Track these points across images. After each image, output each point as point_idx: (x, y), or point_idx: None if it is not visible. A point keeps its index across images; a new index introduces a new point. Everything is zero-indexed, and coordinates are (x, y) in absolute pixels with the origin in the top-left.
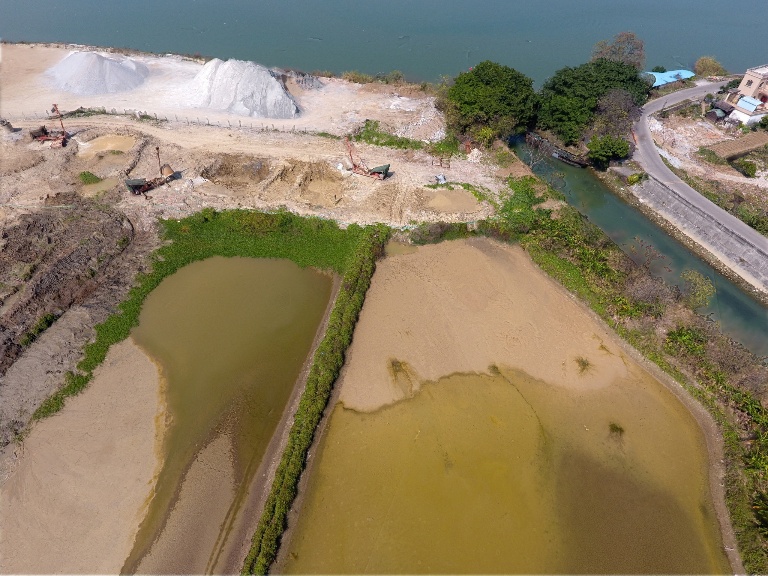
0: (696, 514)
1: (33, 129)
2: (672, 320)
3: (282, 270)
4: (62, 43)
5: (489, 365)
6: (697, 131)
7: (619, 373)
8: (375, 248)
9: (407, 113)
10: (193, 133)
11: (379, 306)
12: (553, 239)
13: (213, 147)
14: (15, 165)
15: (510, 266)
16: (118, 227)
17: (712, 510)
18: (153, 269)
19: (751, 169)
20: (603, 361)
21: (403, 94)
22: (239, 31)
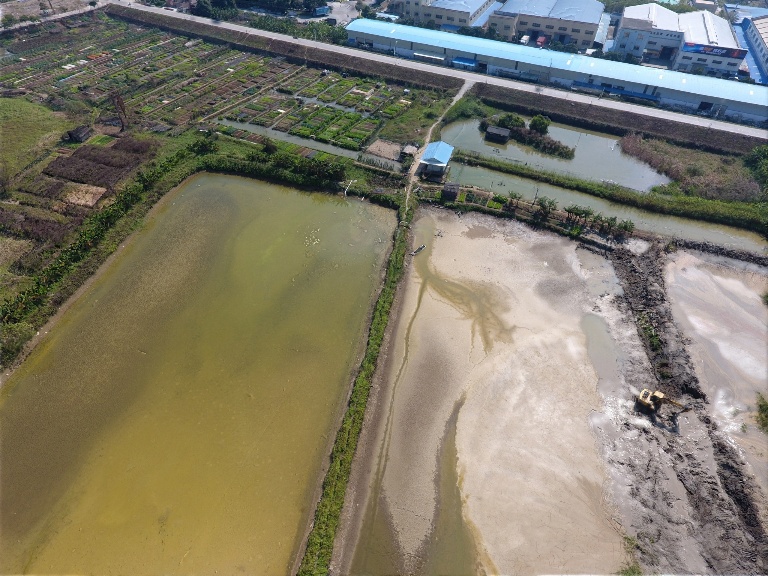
0: None
1: None
2: None
3: None
4: None
5: None
6: None
7: None
8: None
9: None
10: None
11: None
12: None
13: None
14: None
15: None
16: None
17: None
18: None
19: None
20: None
21: None
22: None
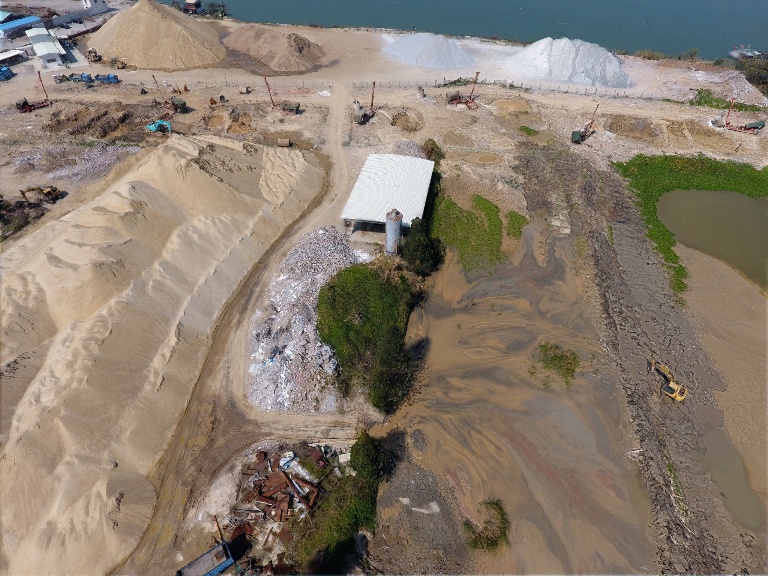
0: None
1: (453, 93)
2: None
3: (737, 200)
4: (370, 27)
5: None
6: None
7: None
8: None
9: (717, 84)
10: (562, 99)
11: None
12: None
13: (592, 109)
14: (458, 121)
15: None
16: (591, 167)
17: None
18: (639, 198)
19: None
20: None
21: (699, 69)
22: (500, 17)
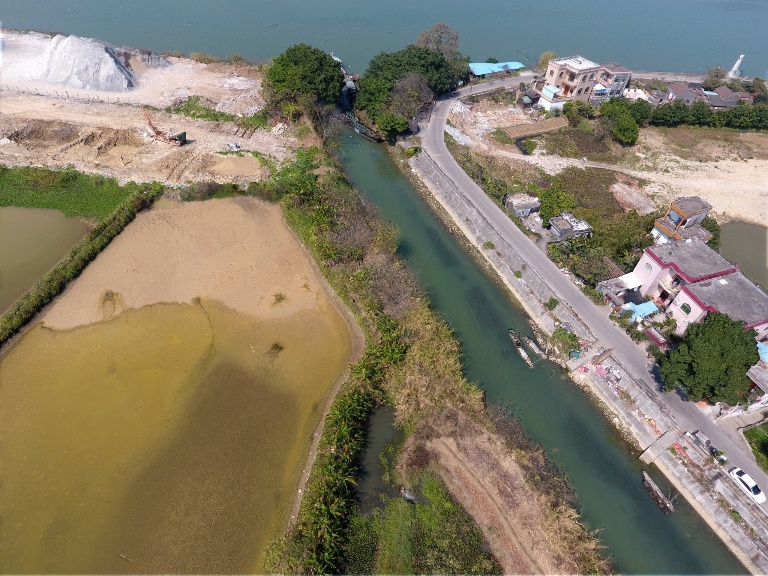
0: (306, 410)
1: None
2: (369, 264)
3: (49, 219)
4: None
5: (194, 297)
6: (503, 115)
7: (307, 306)
8: (135, 201)
9: (237, 91)
10: (19, 101)
11: (120, 249)
12: (301, 197)
13: (32, 114)
14: None
15: (261, 220)
16: None
17: (322, 407)
18: None
19: (531, 148)
20: (299, 296)
21: (242, 74)
22: (114, 14)
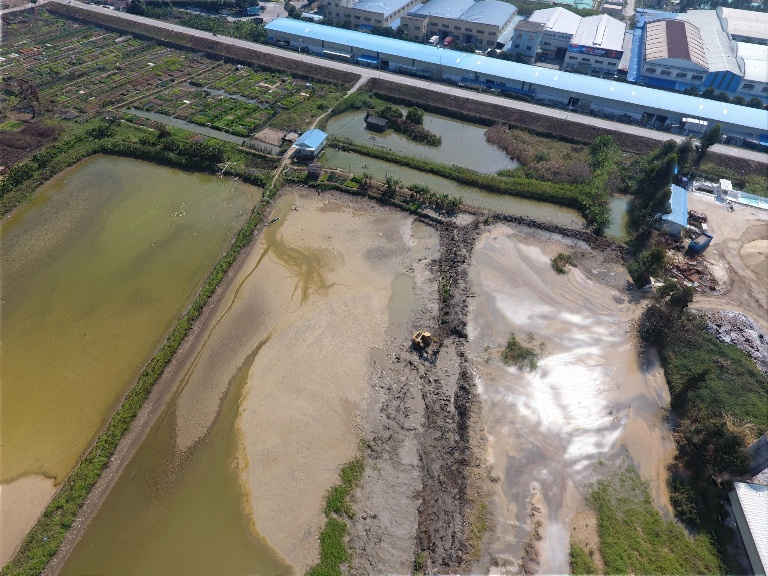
0: None
1: None
2: None
3: None
4: None
5: None
6: None
7: None
8: None
9: None
10: None
11: None
12: None
13: None
14: None
15: None
16: None
17: None
18: None
19: None
20: None
21: None
22: None
